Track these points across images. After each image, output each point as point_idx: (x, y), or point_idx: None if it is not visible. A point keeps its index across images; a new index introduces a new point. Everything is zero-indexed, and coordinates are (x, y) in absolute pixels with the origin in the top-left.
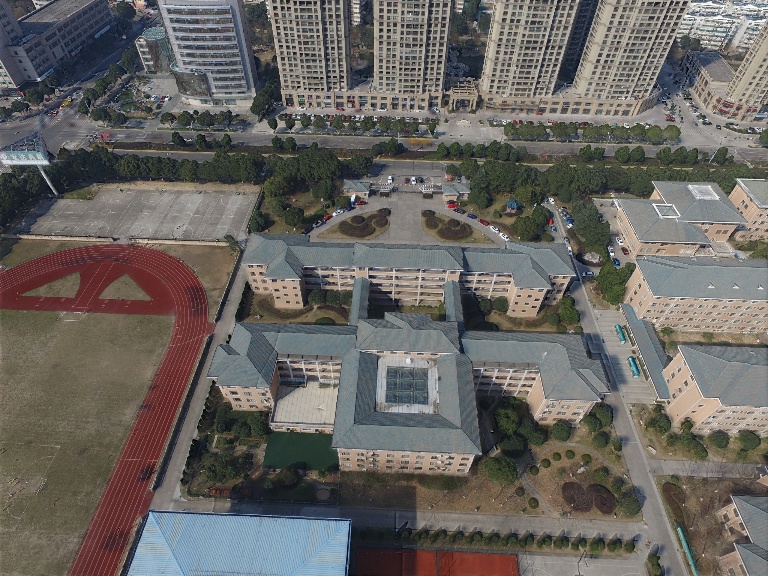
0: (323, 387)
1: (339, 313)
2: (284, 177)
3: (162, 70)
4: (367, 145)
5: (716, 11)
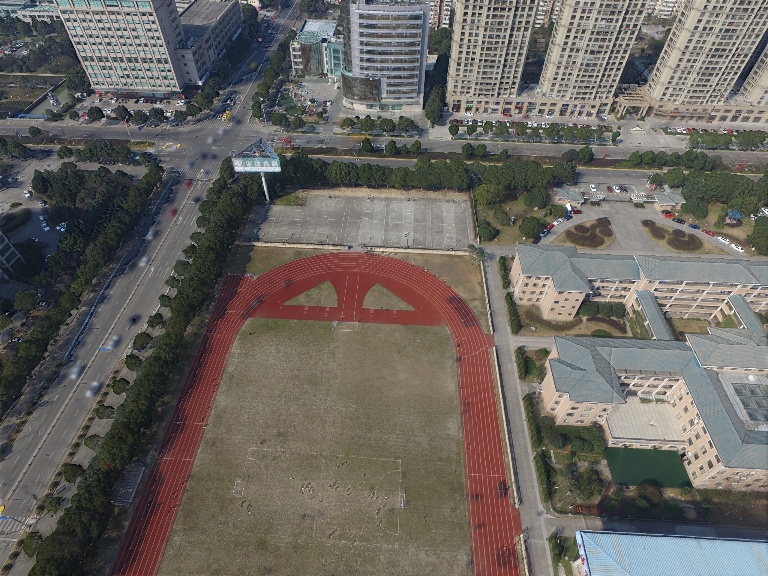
0: (645, 402)
1: (612, 325)
2: (504, 185)
3: (310, 74)
4: (551, 152)
5: None
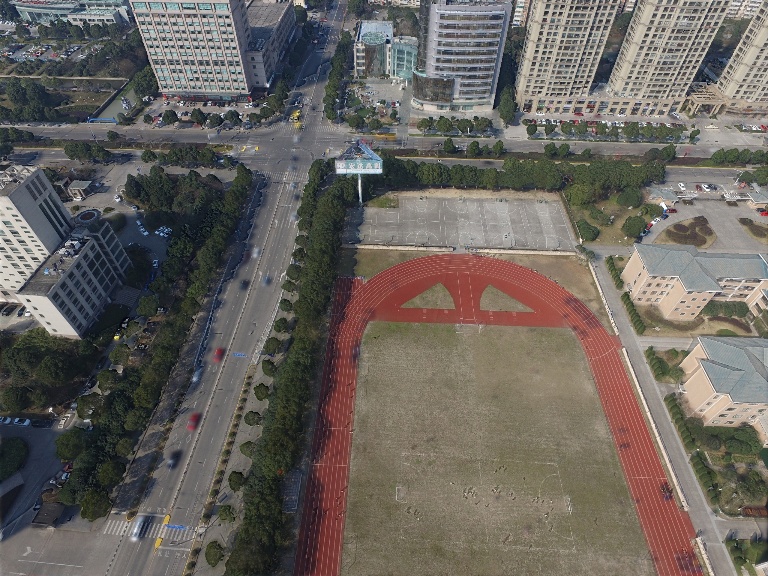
0: None
1: (736, 325)
2: (601, 185)
3: (372, 75)
4: (631, 151)
5: None
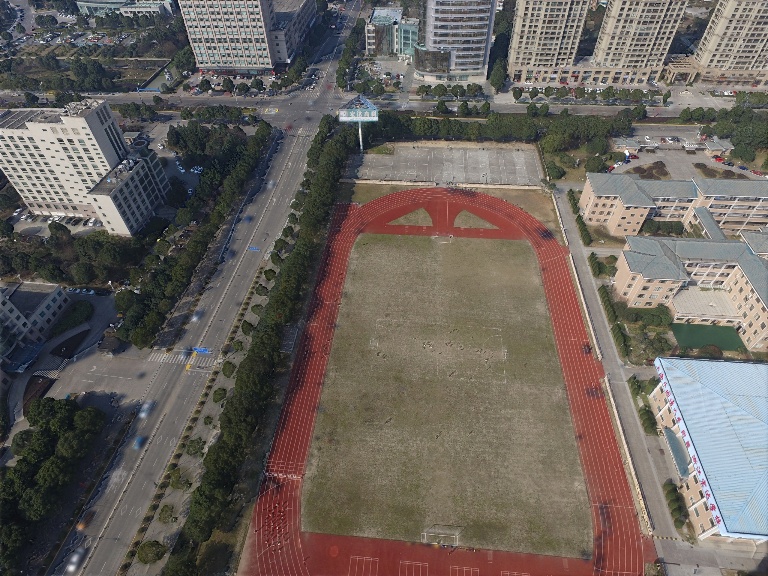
0: (704, 290)
1: None
2: (569, 134)
3: (382, 53)
4: (607, 112)
5: None
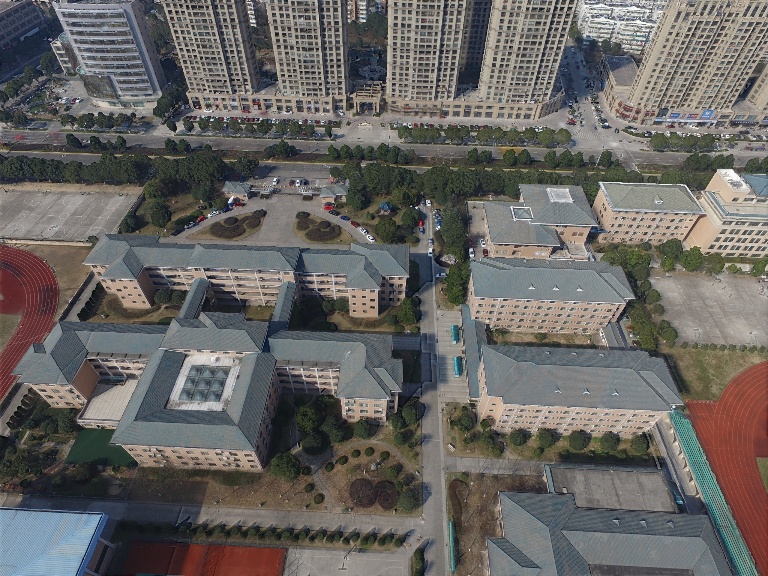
0: None
1: None
2: (161, 179)
3: None
4: (263, 147)
5: (641, 16)
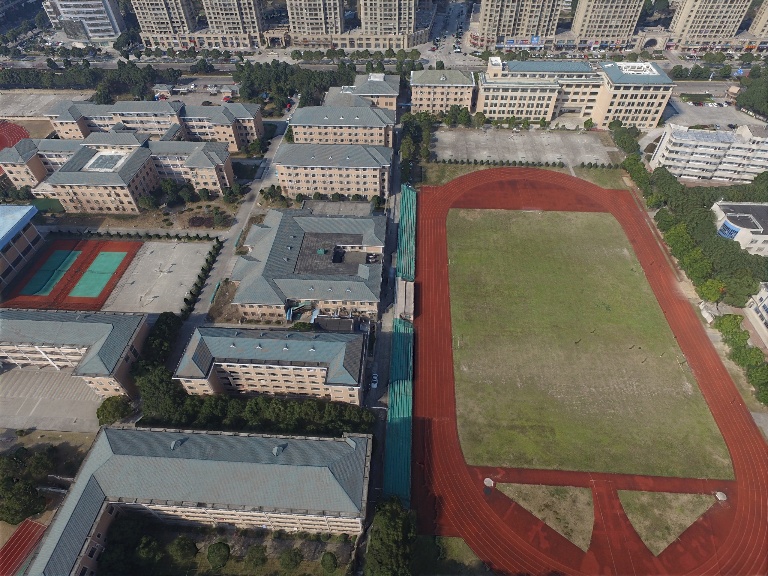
0: None
1: None
2: (107, 79)
3: None
4: None
5: None
